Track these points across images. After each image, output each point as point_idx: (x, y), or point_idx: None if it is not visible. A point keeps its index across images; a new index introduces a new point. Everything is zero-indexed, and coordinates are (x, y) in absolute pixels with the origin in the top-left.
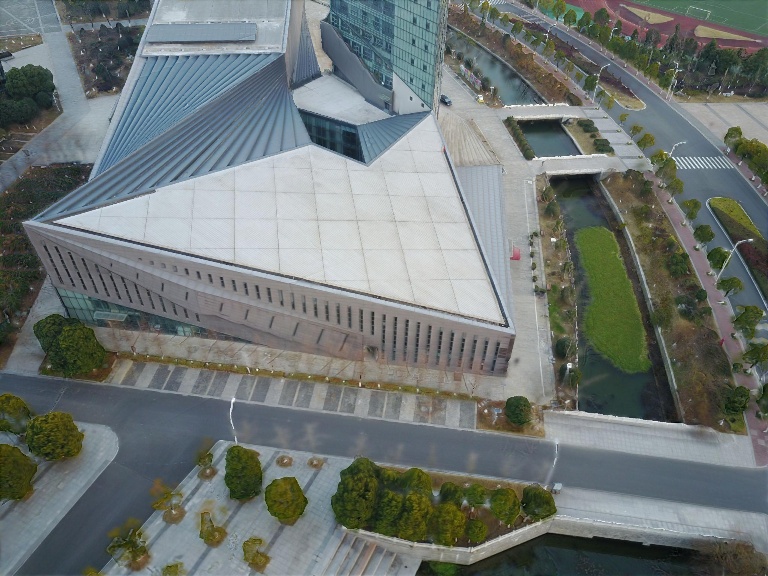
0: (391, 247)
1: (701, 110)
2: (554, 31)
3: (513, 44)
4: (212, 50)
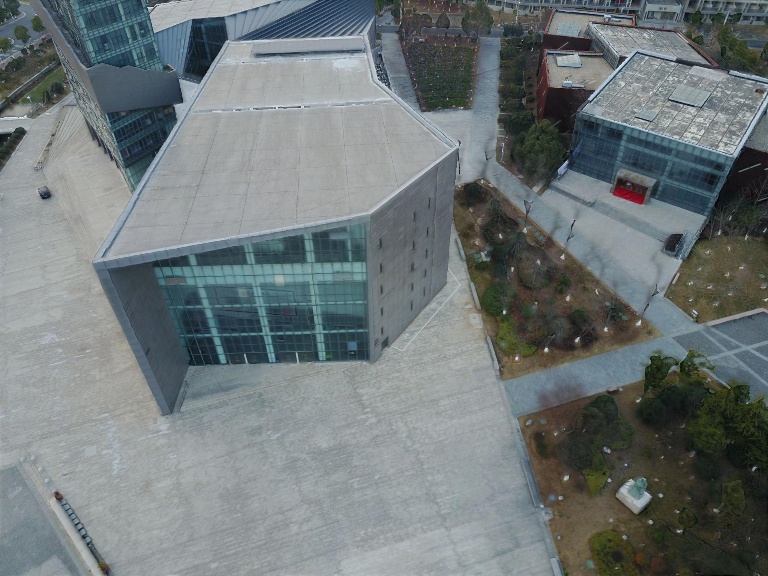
0: (198, 5)
1: None
2: None
3: None
4: None
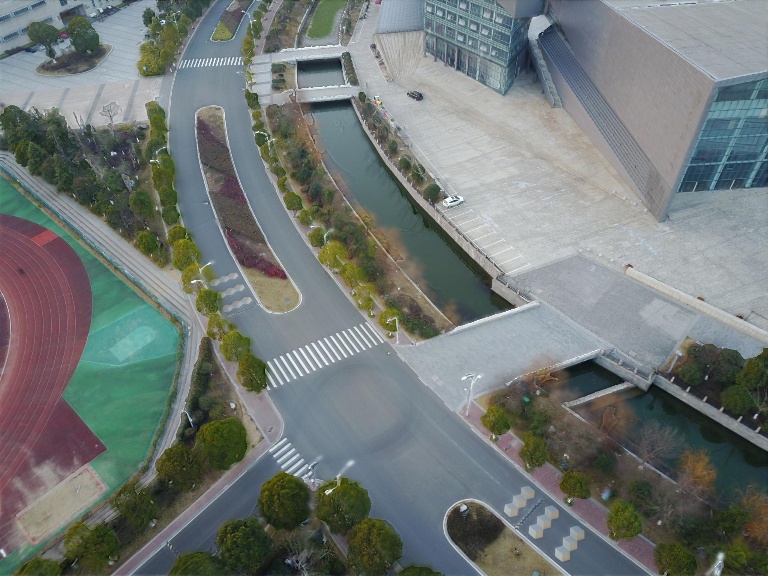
0: None
1: (140, 112)
2: (212, 249)
3: (312, 172)
4: None
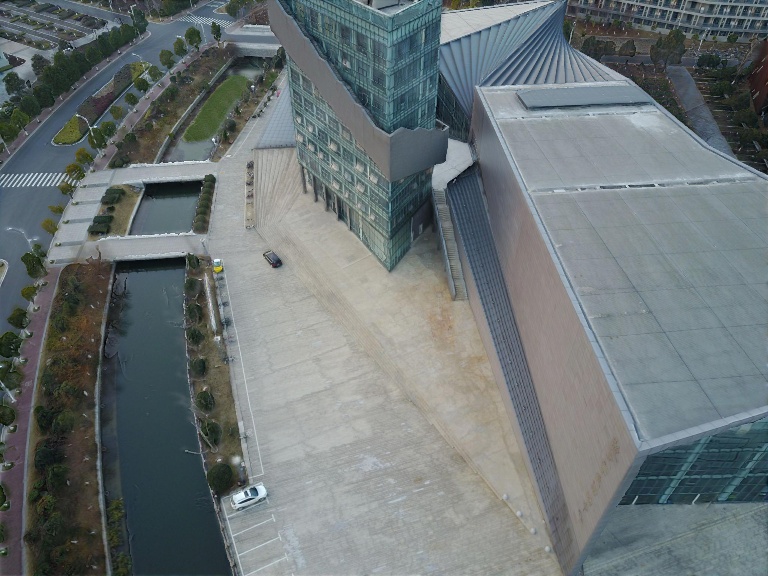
0: None
1: None
2: None
3: (54, 418)
4: (557, 87)
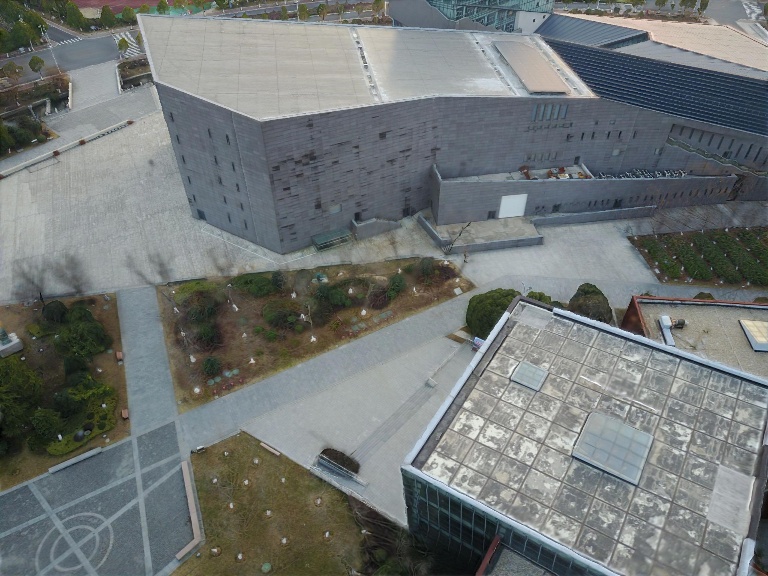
0: None
1: None
2: None
3: None
4: (556, 64)
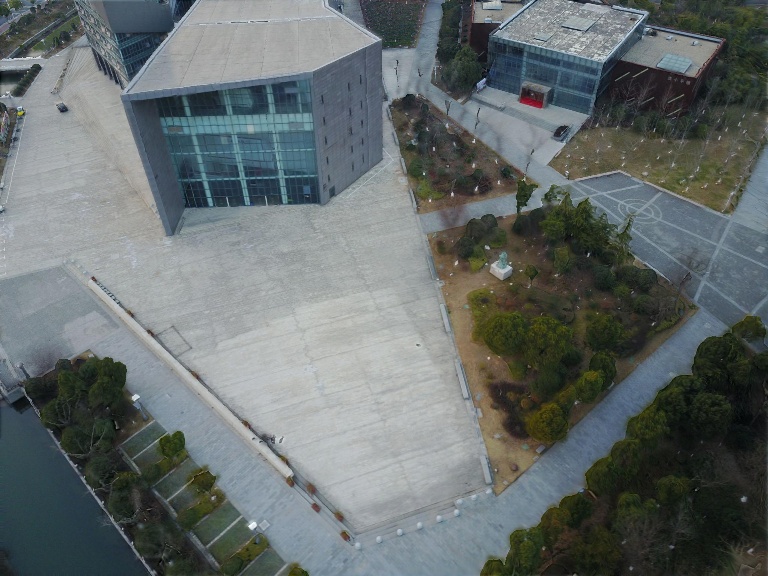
0: None
1: None
2: None
3: None
4: None
